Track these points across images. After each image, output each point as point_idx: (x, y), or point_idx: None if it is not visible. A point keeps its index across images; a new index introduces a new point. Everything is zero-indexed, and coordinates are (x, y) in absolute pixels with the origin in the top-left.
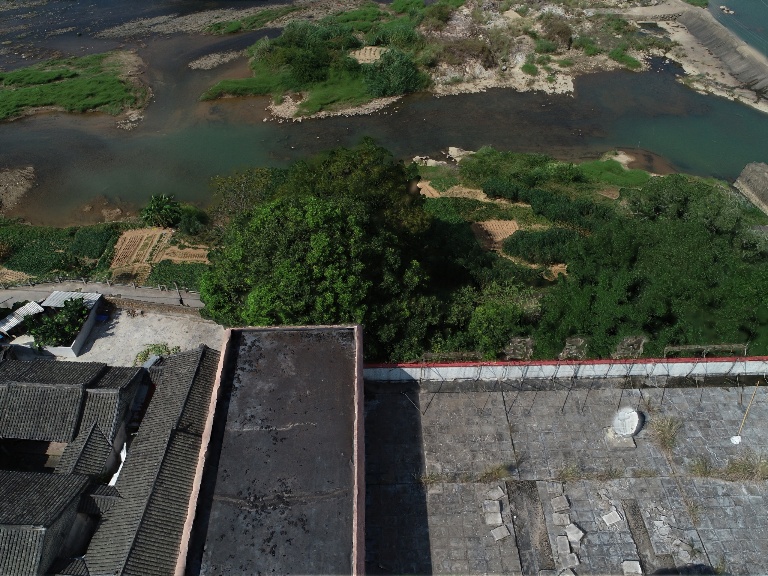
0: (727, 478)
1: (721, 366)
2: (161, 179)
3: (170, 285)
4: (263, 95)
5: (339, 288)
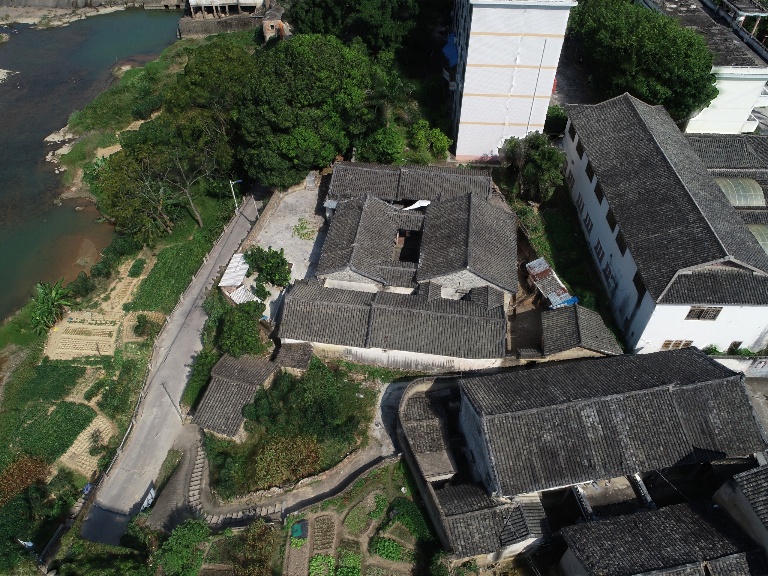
0: None
1: None
2: None
3: (175, 288)
4: None
5: None
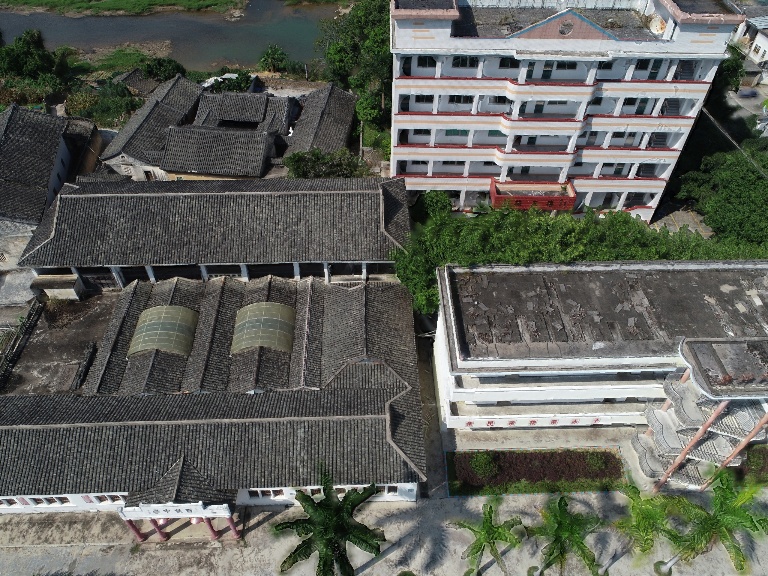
0: (603, 27)
1: (609, 2)
2: (264, 50)
3: None
4: (332, 3)
5: None
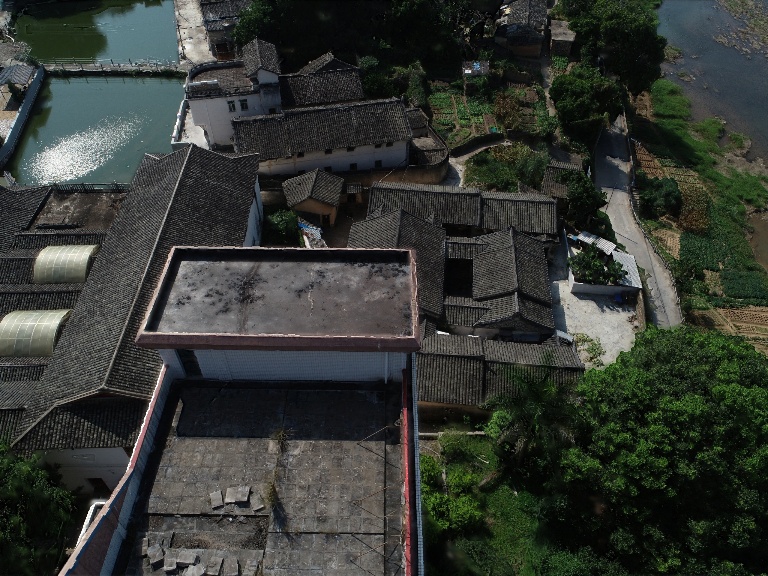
0: None
1: None
2: None
3: None
4: None
5: (641, 447)
